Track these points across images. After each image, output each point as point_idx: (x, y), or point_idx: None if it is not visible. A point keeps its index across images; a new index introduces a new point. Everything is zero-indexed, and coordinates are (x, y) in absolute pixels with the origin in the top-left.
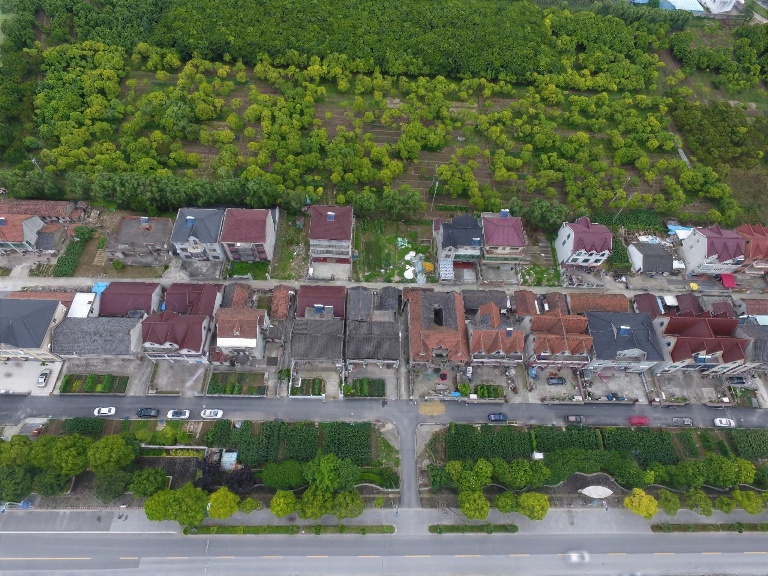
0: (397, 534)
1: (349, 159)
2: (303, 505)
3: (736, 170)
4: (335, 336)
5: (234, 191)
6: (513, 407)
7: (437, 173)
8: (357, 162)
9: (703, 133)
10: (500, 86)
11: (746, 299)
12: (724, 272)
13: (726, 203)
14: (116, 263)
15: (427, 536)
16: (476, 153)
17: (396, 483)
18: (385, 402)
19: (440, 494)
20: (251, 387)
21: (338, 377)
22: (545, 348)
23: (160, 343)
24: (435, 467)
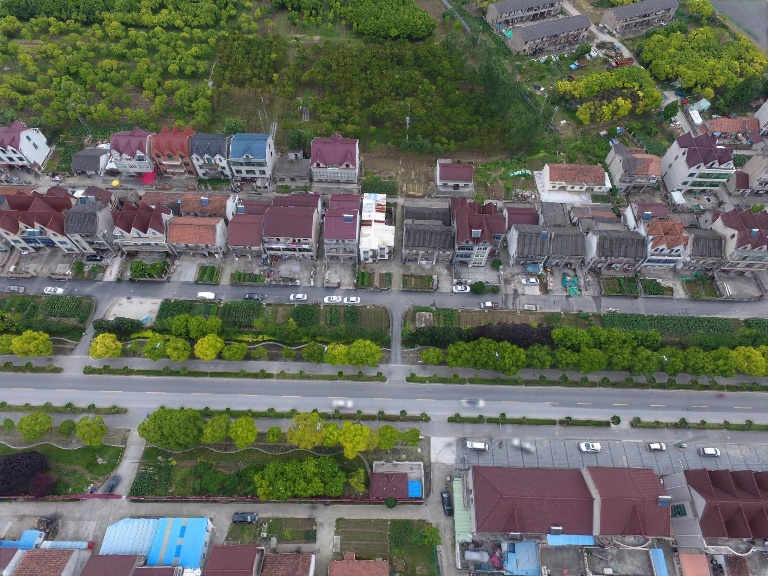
0: None
1: None
2: None
3: (231, 88)
4: None
5: None
6: None
7: None
8: None
9: (230, 59)
10: (67, 24)
11: (150, 192)
12: (144, 170)
13: (195, 115)
14: None
15: None
16: None
17: None
18: None
19: None
20: None
21: None
22: None
23: None
24: None
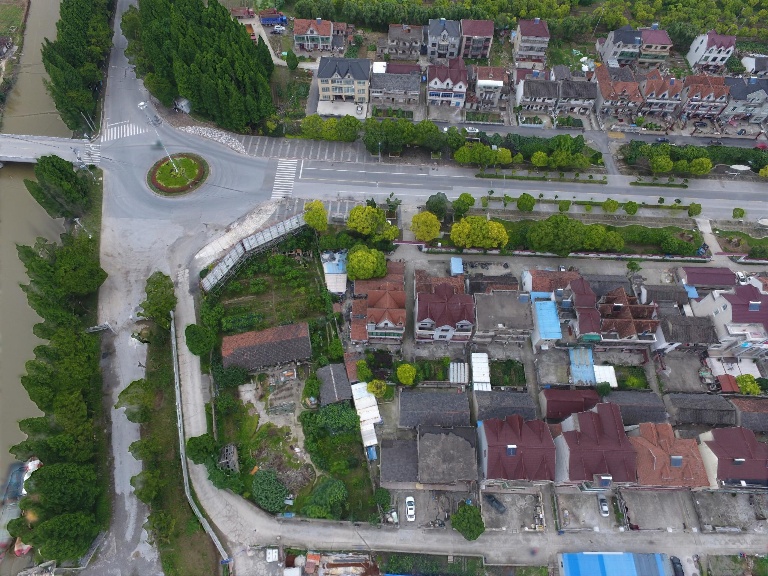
0: (609, 185)
1: (532, 1)
2: (554, 157)
3: None
4: (553, 83)
5: (462, 12)
6: (672, 137)
7: (594, 14)
8: (538, 3)
9: None
10: None
11: None
12: None
13: None
14: (387, 54)
15: (629, 187)
16: (621, 3)
17: (603, 164)
18: (584, 131)
19: (633, 169)
20: (493, 120)
21: (549, 118)
22: (697, 91)
23: (441, 82)
24: (630, 152)
